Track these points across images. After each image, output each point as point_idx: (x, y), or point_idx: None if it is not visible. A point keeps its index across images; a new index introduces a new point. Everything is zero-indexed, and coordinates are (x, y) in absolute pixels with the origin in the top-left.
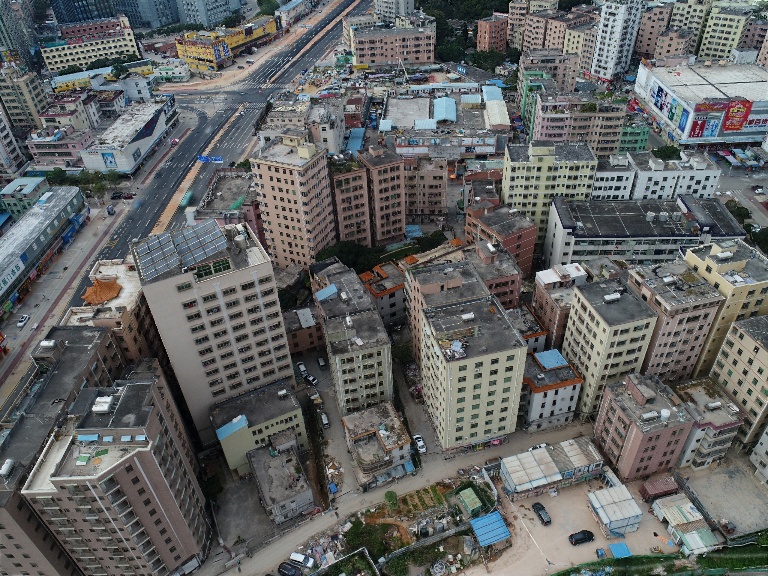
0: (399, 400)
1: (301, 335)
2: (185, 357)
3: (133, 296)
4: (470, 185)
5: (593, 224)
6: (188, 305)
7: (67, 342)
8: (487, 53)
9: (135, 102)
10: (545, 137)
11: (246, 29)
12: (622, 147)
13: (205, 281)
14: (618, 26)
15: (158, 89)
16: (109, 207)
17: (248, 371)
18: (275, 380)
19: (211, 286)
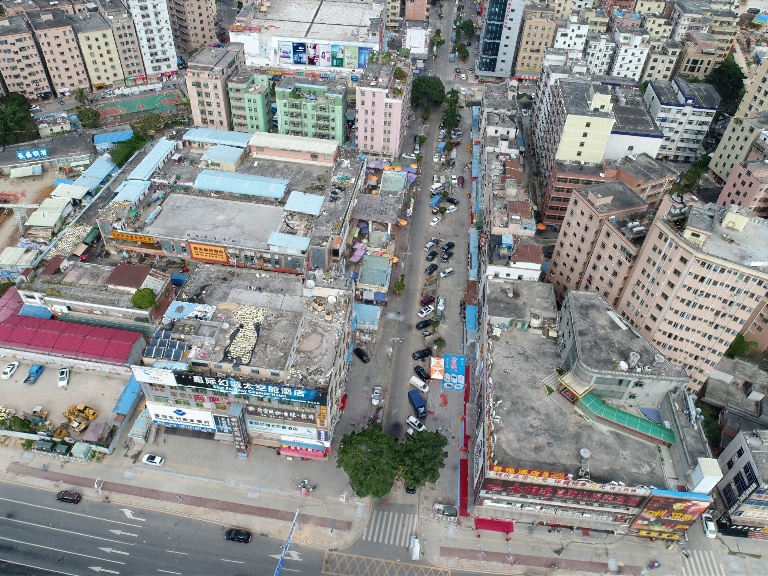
0: None
1: None
2: None
3: None
4: None
5: None
6: None
7: None
8: (11, 115)
9: None
10: None
11: None
12: None
13: None
14: (162, 3)
15: None
16: None
17: None
18: None
19: None
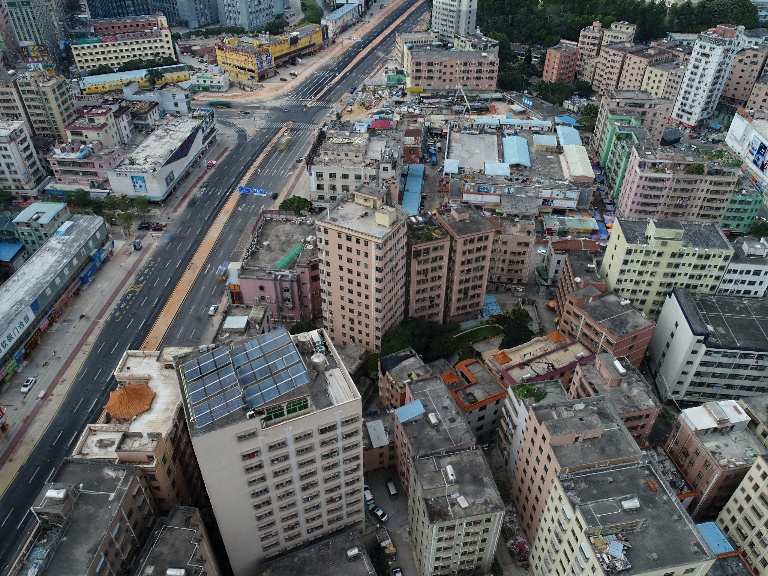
0: (495, 559)
1: (370, 455)
2: (235, 512)
3: (169, 410)
4: (560, 255)
5: (726, 329)
6: (248, 455)
7: (82, 485)
8: (556, 85)
9: (170, 115)
10: (639, 197)
11: (291, 38)
12: (727, 215)
13: (274, 426)
14: (711, 69)
15: (194, 98)
16: (136, 241)
17: (311, 520)
18: (341, 526)
19: (281, 431)
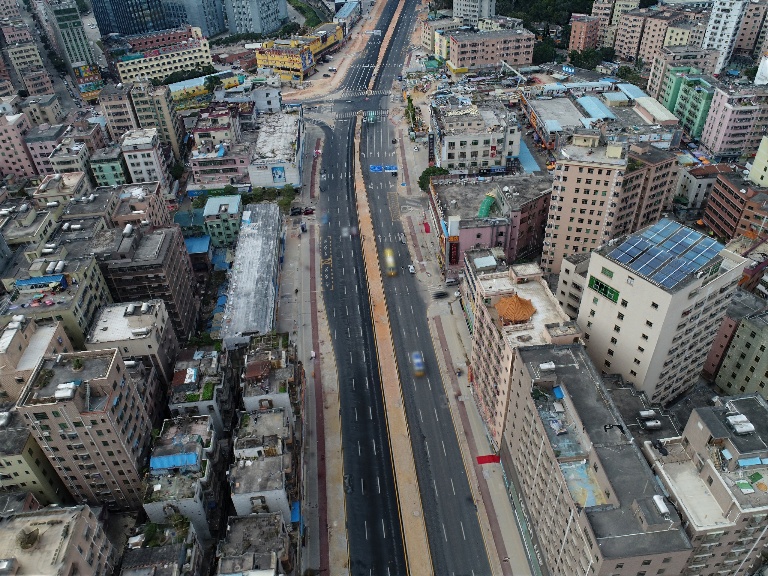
0: None
1: None
2: (655, 369)
3: (551, 310)
4: (701, 179)
5: None
6: (685, 313)
7: None
8: (587, 53)
9: (264, 114)
10: (731, 130)
11: (322, 36)
12: None
13: (706, 286)
14: (732, 22)
15: None
16: (303, 223)
17: (679, 380)
18: (686, 388)
19: (706, 291)
